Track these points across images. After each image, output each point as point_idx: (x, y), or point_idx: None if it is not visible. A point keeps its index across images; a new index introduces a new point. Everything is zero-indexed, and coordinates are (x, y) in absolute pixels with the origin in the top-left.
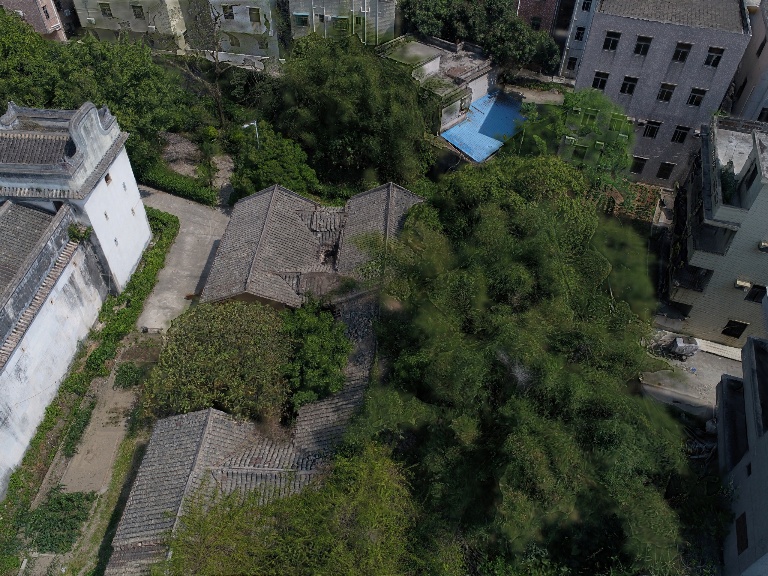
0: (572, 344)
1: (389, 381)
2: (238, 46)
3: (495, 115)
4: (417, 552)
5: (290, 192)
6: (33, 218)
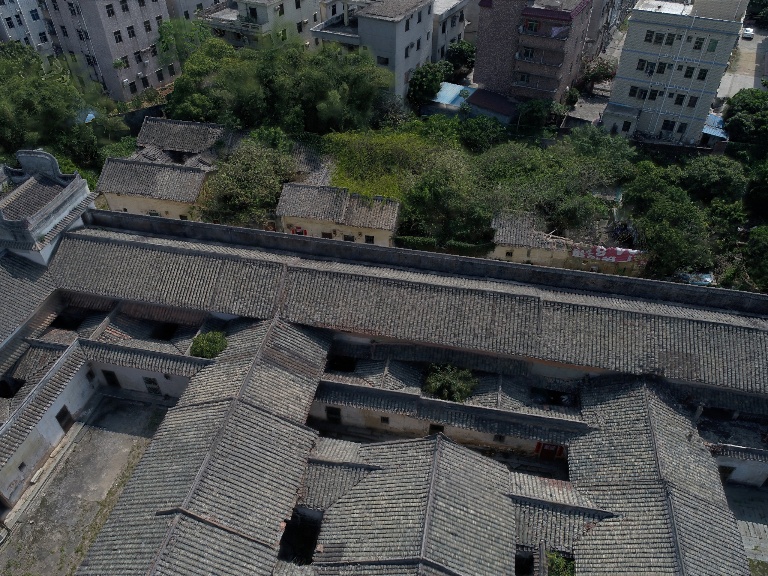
0: None
1: (299, 127)
2: None
3: None
4: (374, 135)
5: None
6: None
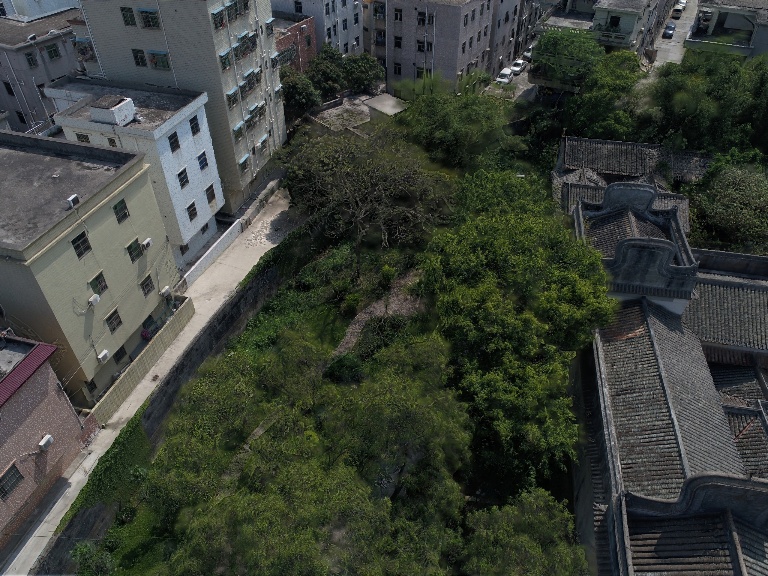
0: (762, 67)
1: (749, 147)
2: (187, 250)
3: None
4: None
5: None
6: None
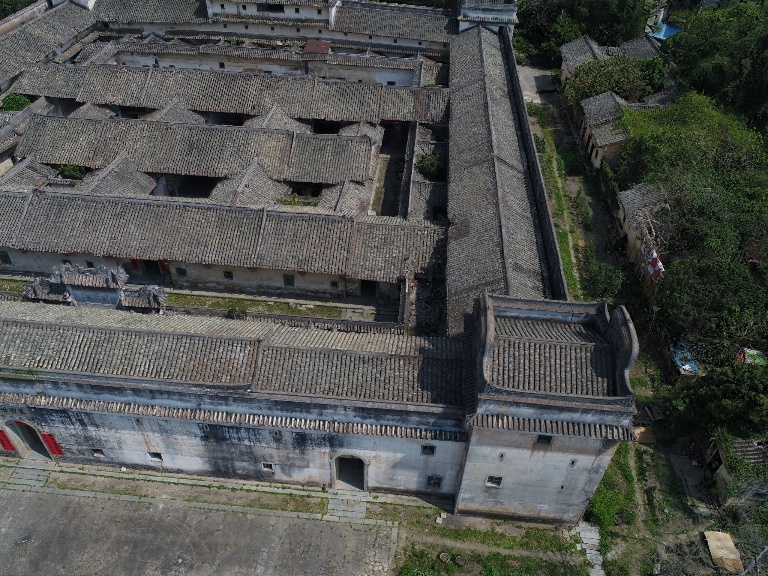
0: None
1: None
2: None
3: (669, 31)
4: None
5: (592, 40)
6: (490, 33)
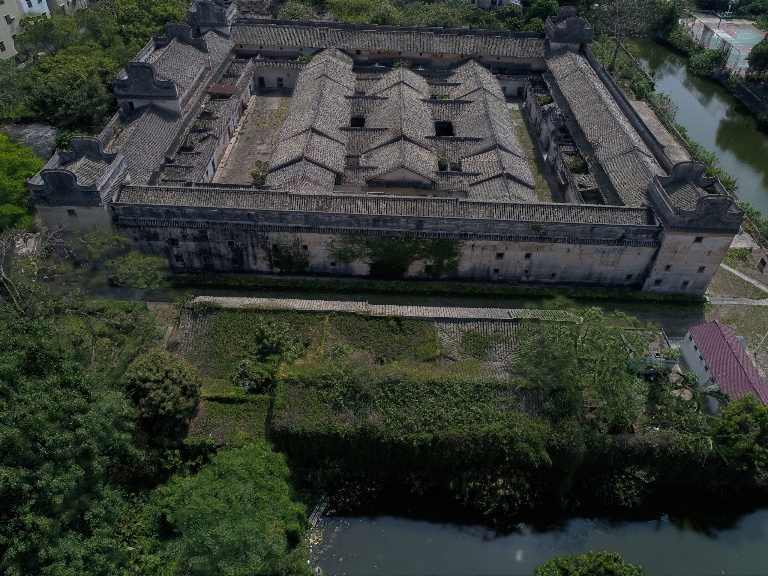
0: None
1: None
2: None
3: None
4: None
5: None
6: None
